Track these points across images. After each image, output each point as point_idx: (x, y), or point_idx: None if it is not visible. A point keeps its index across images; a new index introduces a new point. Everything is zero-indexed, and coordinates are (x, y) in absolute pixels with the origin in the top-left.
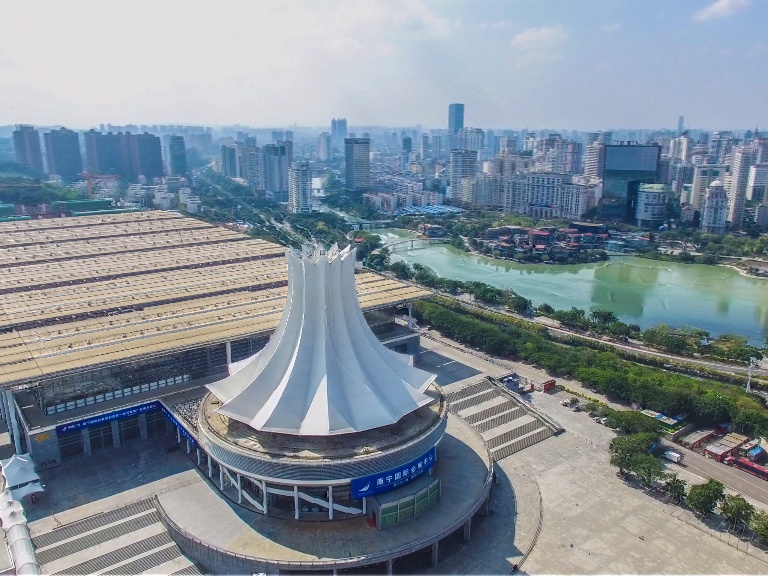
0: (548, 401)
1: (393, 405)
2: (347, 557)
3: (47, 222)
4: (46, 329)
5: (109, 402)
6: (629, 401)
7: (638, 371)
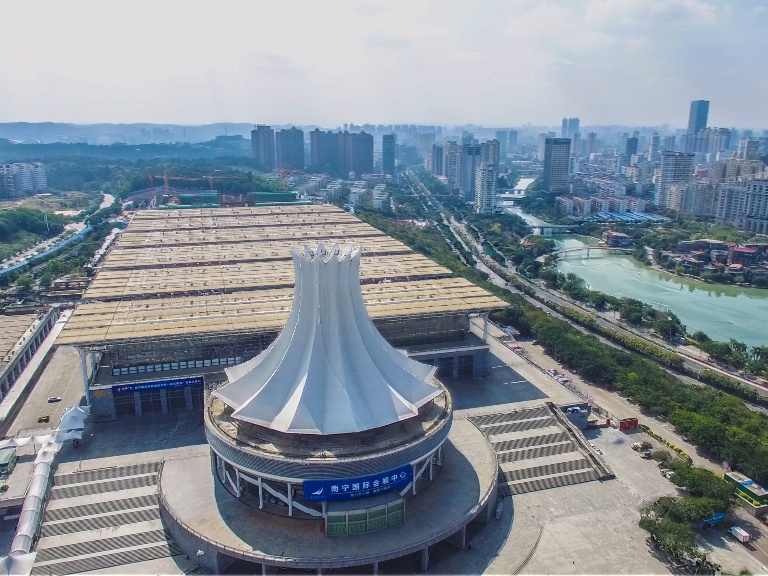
0: (618, 441)
1: (374, 414)
2: (278, 555)
3: (228, 210)
4: (141, 302)
5: (165, 372)
6: (720, 458)
7: (755, 424)
